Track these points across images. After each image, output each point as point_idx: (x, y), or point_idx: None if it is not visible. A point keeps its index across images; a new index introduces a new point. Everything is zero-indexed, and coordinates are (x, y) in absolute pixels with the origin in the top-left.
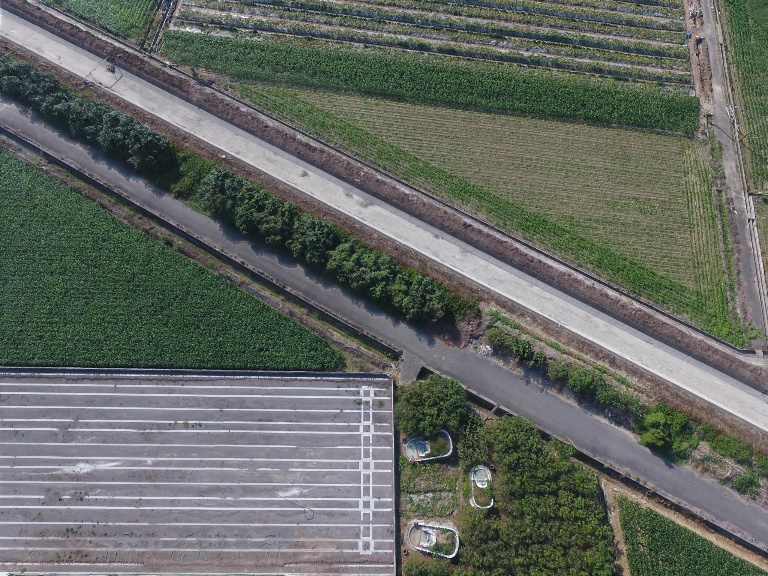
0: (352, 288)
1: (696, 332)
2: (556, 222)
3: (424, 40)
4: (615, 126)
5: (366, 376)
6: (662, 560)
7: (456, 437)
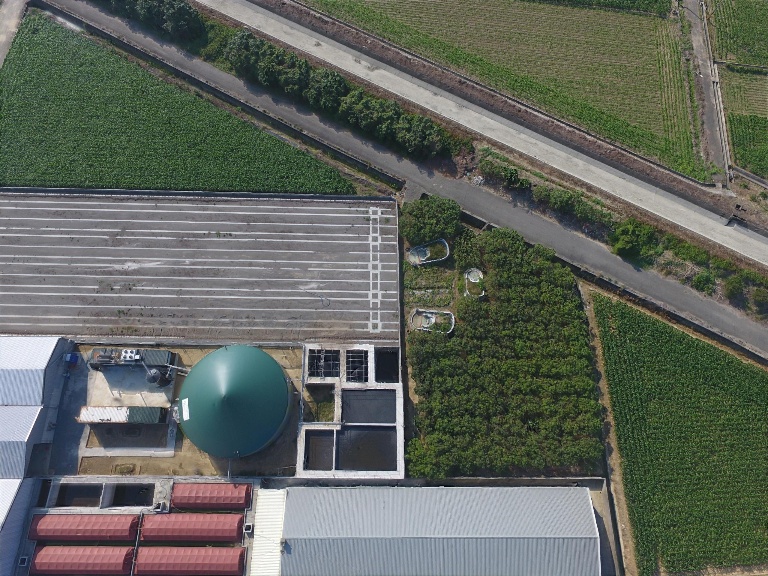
0: (361, 131)
1: (664, 169)
2: (541, 83)
3: None
4: (595, 7)
5: (374, 199)
6: (629, 339)
7: (452, 247)
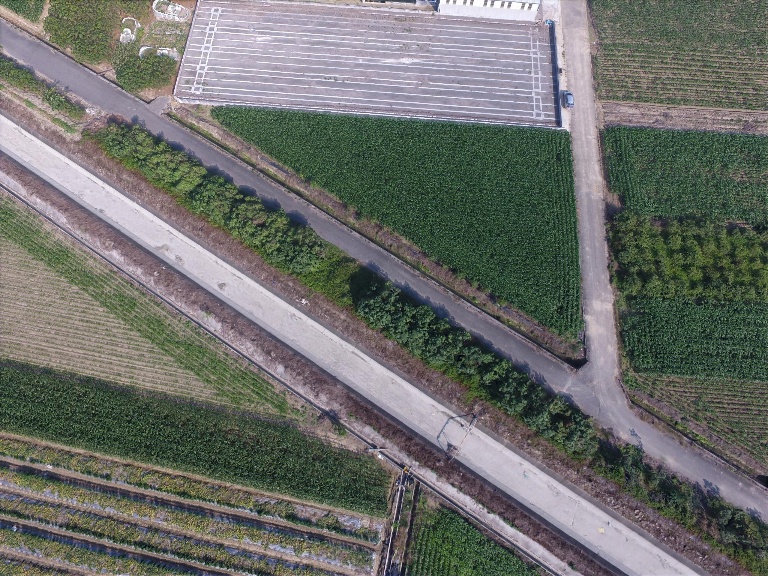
0: None
1: None
2: None
3: (21, 487)
4: None
5: None
6: None
7: None
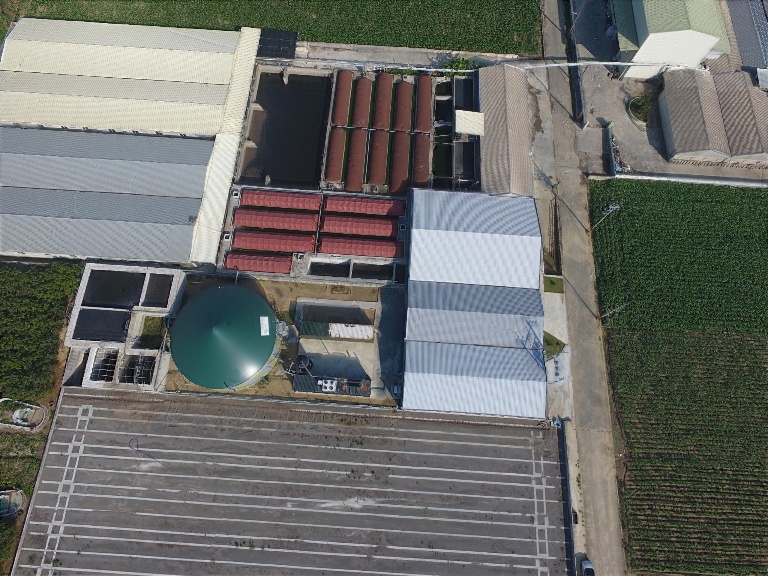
0: None
1: None
2: None
3: None
4: None
5: None
6: None
7: None
